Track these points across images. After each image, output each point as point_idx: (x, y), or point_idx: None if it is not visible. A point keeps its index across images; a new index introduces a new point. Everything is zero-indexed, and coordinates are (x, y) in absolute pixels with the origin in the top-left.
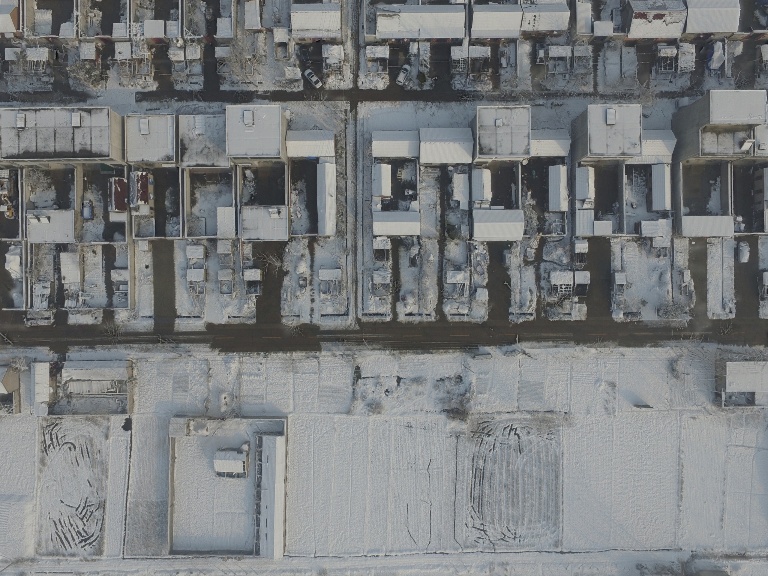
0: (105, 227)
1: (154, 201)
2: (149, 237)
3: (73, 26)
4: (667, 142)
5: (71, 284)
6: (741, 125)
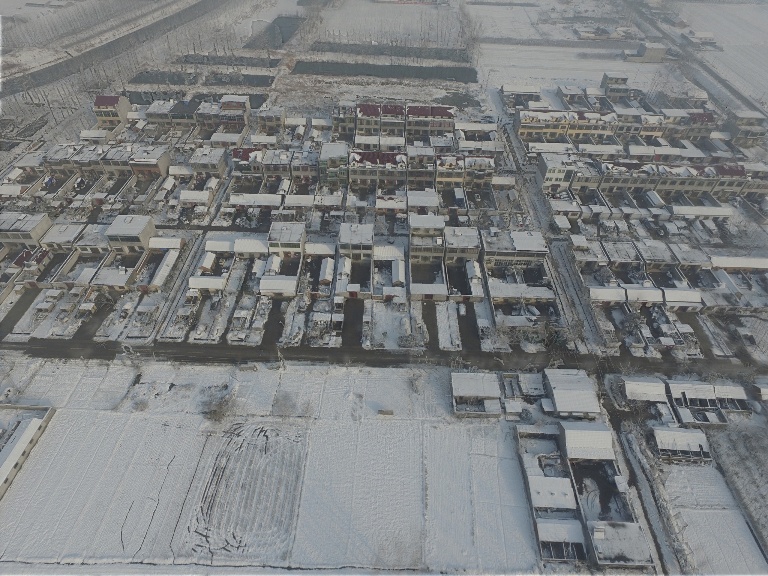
0: None
1: (45, 269)
2: (25, 280)
3: (54, 194)
4: (398, 248)
5: None
6: (436, 234)
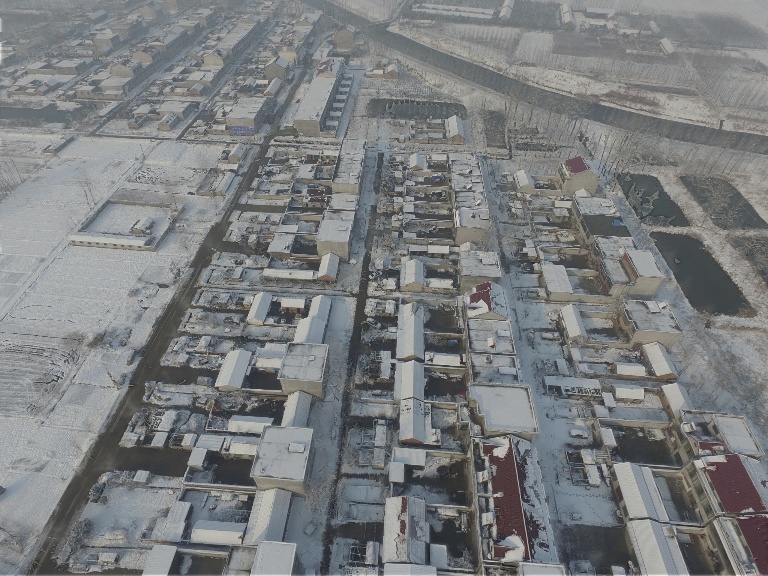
0: None
1: (312, 208)
2: None
3: (412, 184)
4: (265, 533)
5: None
6: None
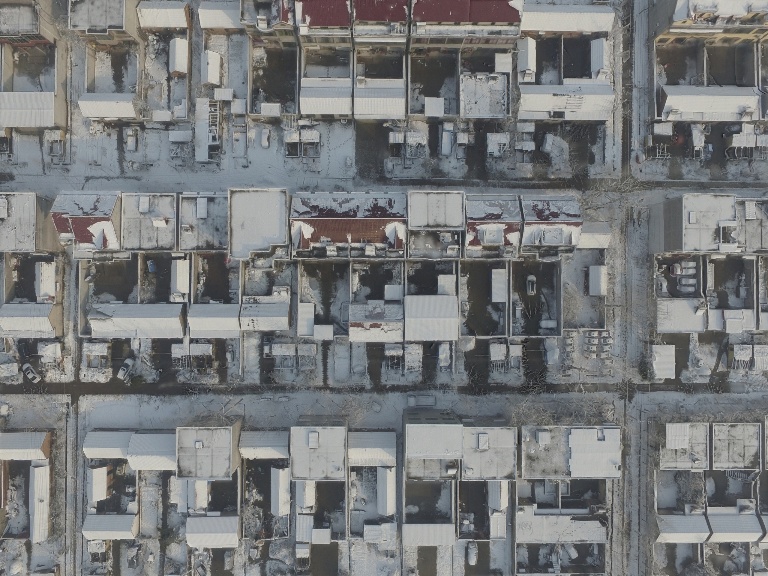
0: None
1: None
2: None
3: None
4: (387, 449)
5: None
6: None
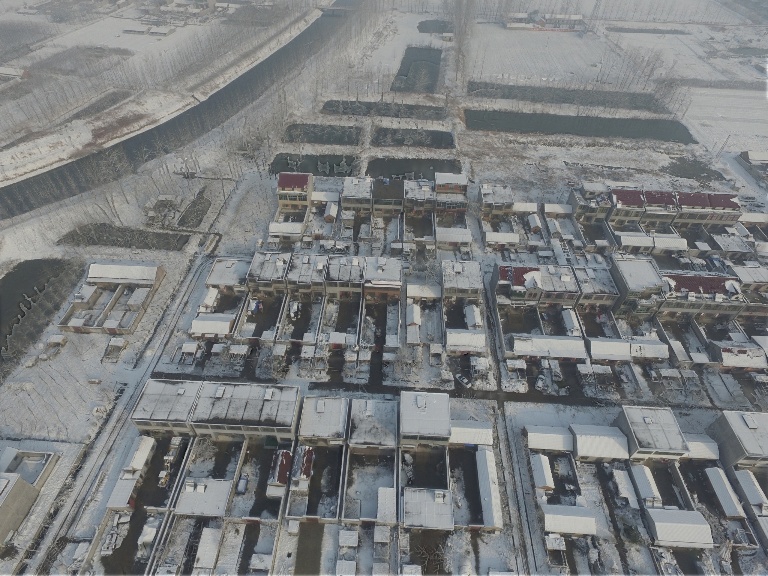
0: (255, 503)
1: (310, 479)
2: (305, 515)
3: (274, 333)
4: None
5: (201, 570)
6: None
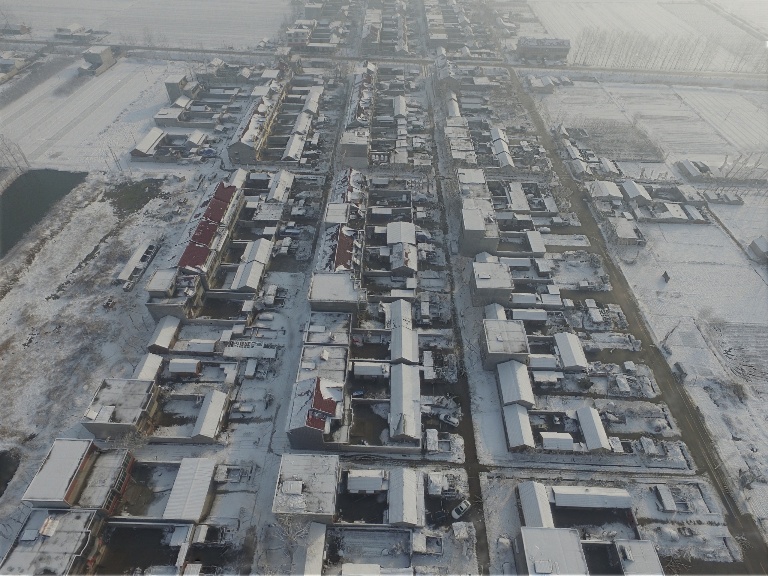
0: None
1: None
2: None
3: None
4: (487, 256)
5: None
6: None
